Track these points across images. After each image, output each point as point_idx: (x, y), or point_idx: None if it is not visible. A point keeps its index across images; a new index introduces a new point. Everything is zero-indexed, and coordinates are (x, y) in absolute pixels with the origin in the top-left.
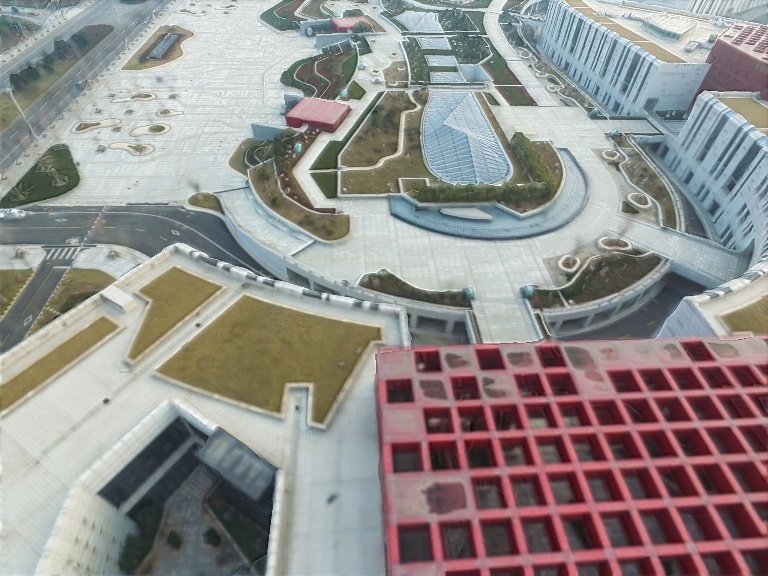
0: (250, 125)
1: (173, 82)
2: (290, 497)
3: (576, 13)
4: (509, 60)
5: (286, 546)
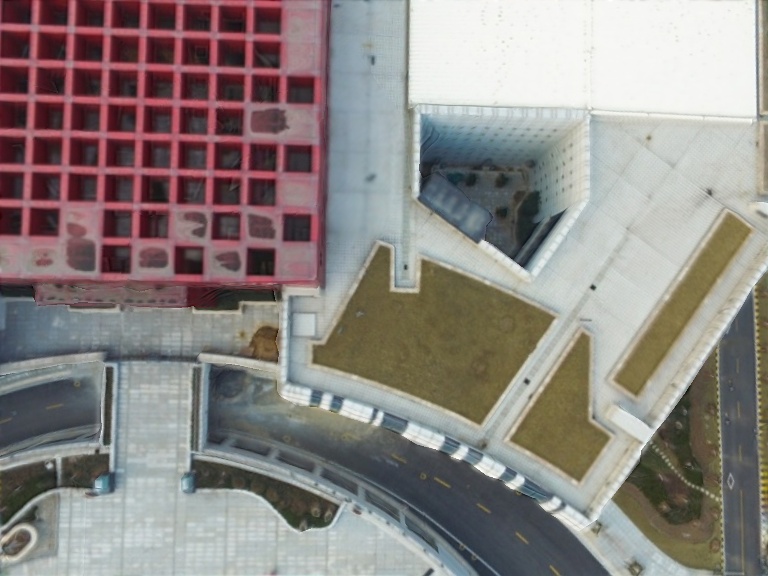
0: None
1: None
2: (406, 182)
3: None
4: None
5: (407, 145)
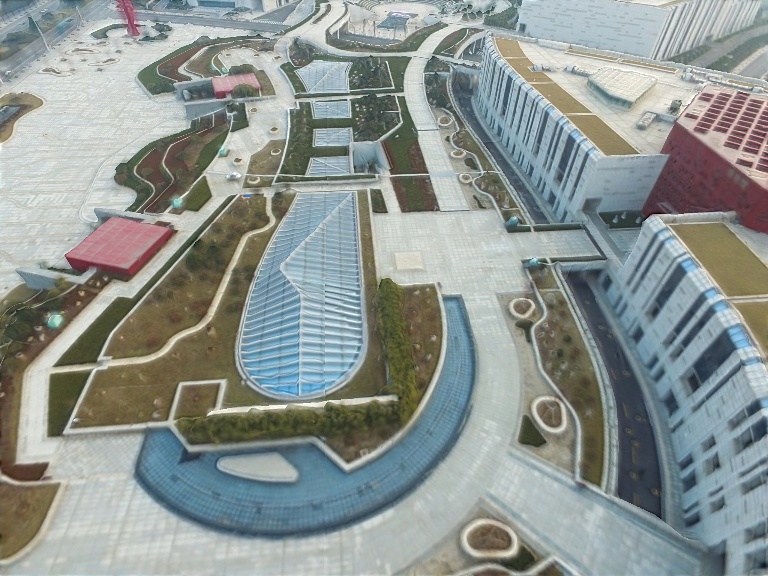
0: (39, 257)
1: None
2: None
3: (505, 68)
4: (422, 130)
5: None
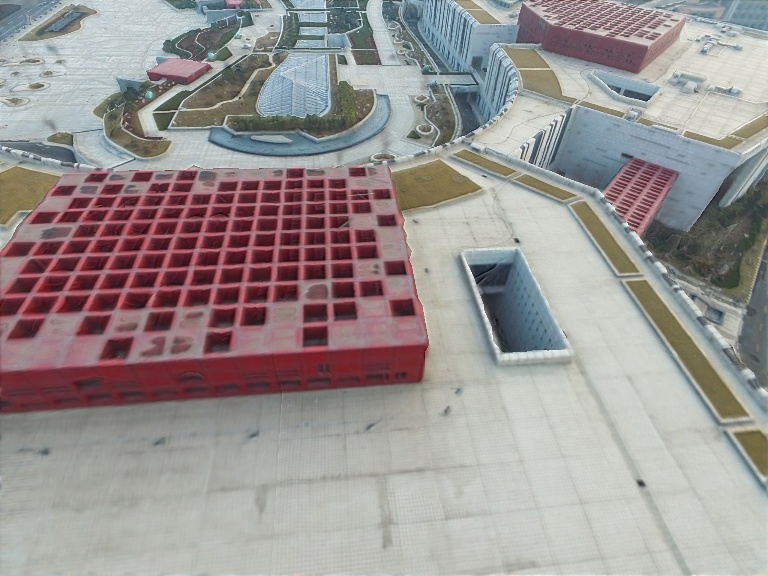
0: None
1: (63, 50)
2: None
3: None
4: (377, 31)
5: None
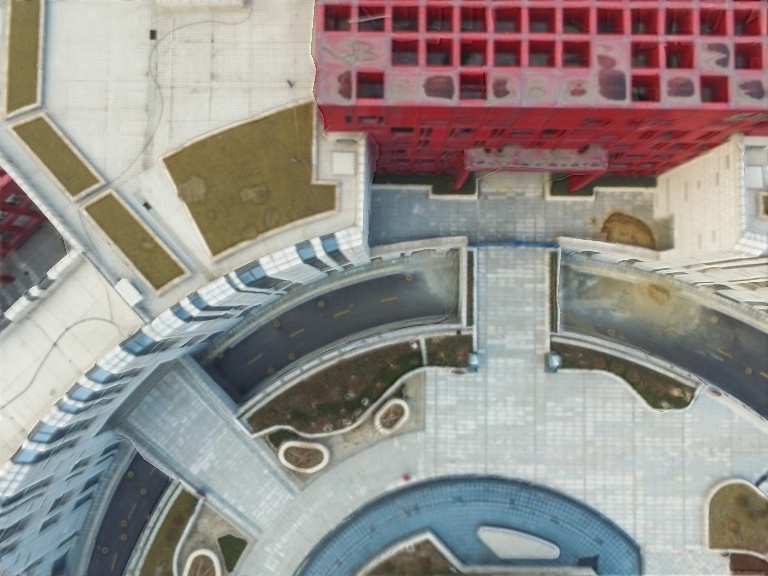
0: None
1: None
2: None
3: None
4: None
5: None
